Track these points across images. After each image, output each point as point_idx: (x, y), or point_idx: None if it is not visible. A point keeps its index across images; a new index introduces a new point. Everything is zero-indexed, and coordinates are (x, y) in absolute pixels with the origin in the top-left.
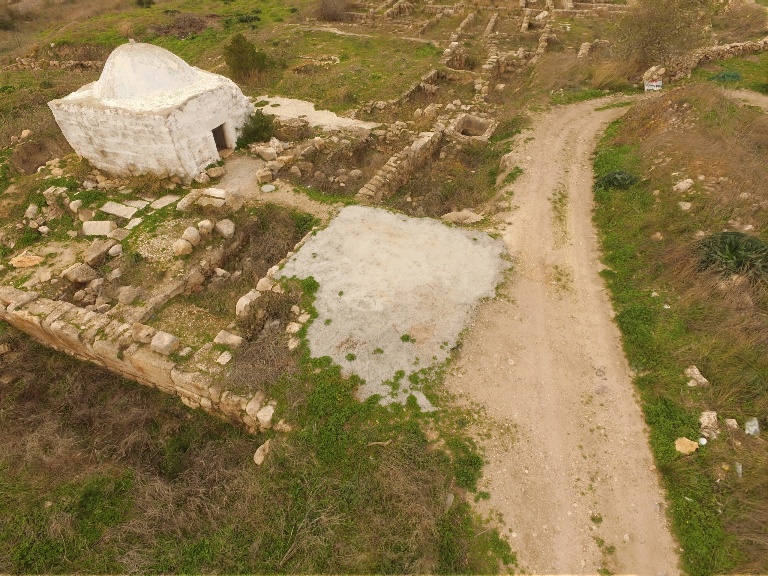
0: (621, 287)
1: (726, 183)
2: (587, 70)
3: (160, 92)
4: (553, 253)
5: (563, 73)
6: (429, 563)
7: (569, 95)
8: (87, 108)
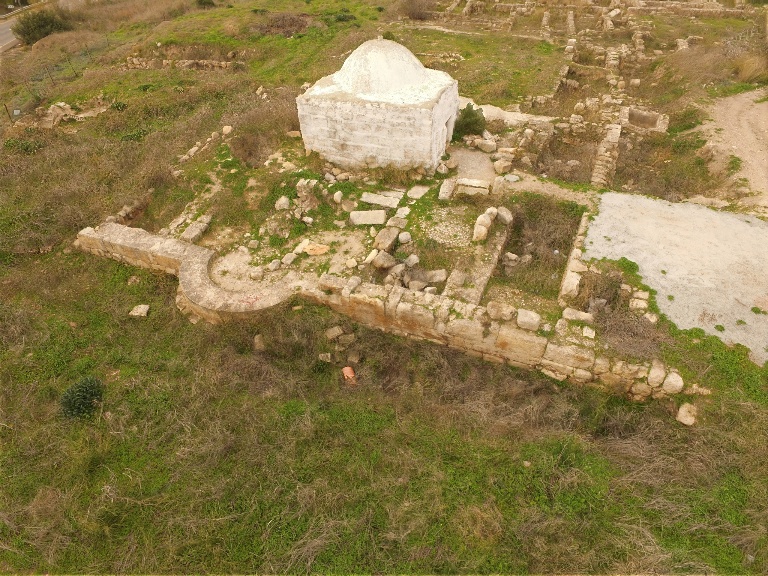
0: None
1: None
2: (732, 64)
3: (410, 86)
4: None
5: (705, 68)
6: None
7: (722, 88)
8: (344, 102)
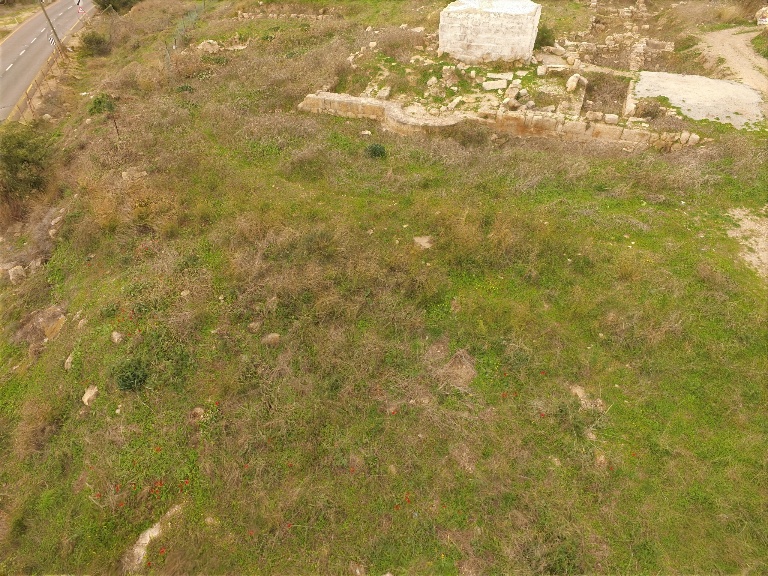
0: None
1: None
2: (716, 11)
3: (516, 5)
4: None
5: (697, 14)
6: None
7: (710, 27)
8: (475, 14)
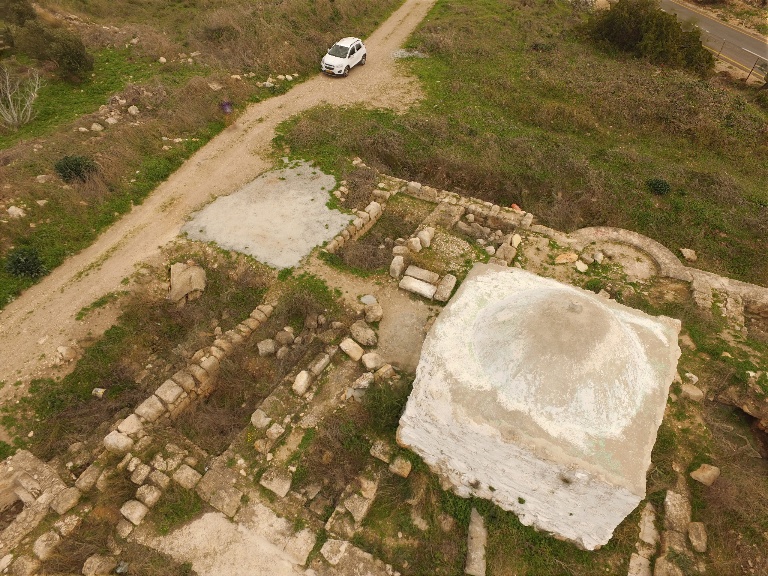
0: (143, 190)
1: (1, 194)
2: None
3: None
4: (154, 220)
5: None
6: None
7: None
8: None
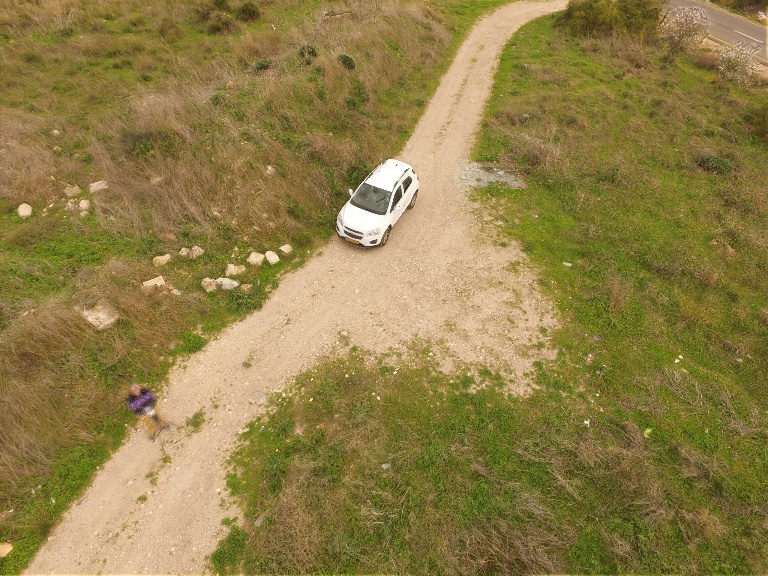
0: None
1: None
2: None
3: None
4: None
5: None
6: (294, 464)
7: None
8: None
